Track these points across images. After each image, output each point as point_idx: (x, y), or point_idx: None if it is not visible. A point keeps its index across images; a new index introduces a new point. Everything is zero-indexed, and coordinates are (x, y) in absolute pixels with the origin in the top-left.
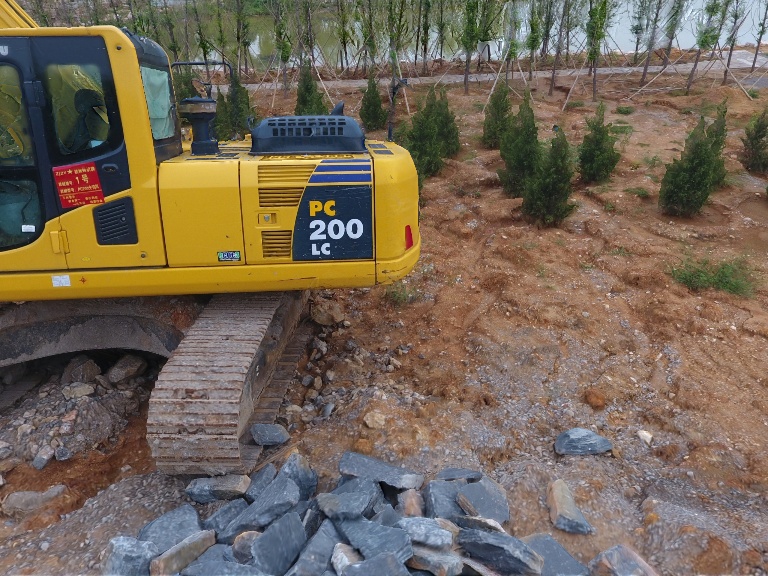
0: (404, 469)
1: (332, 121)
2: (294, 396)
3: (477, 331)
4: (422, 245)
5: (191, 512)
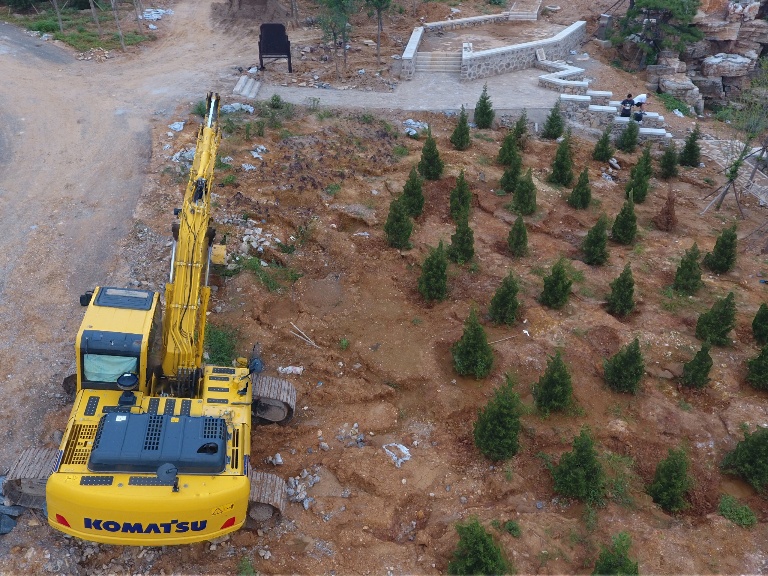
0: None
1: None
2: None
3: None
4: None
5: None
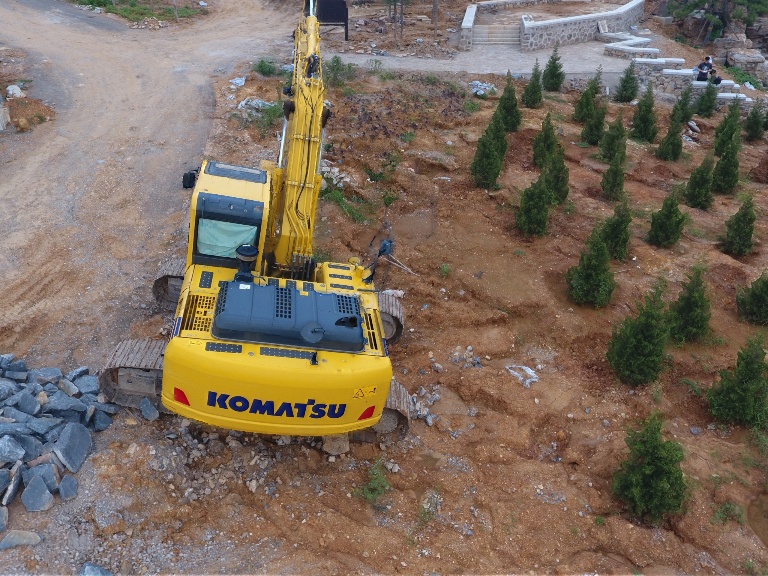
0: (78, 459)
1: None
2: (213, 427)
3: None
4: (504, 517)
5: (97, 388)
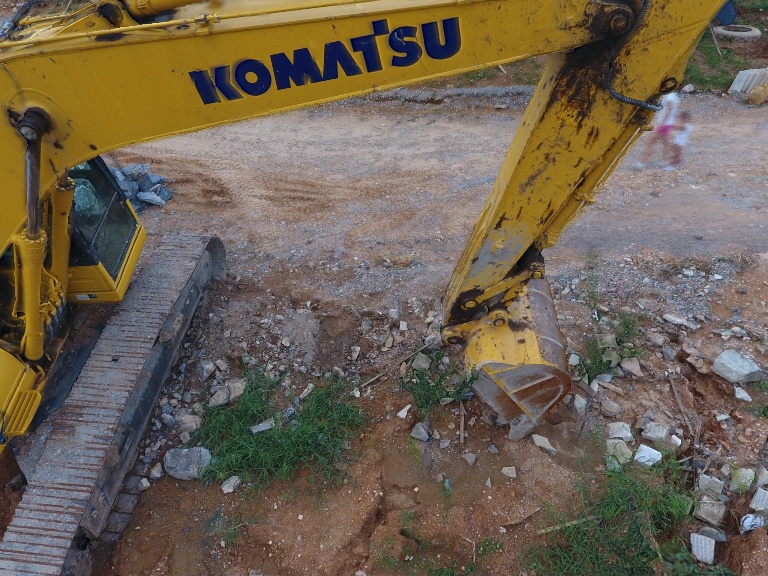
0: None
1: None
2: None
3: None
4: None
5: None
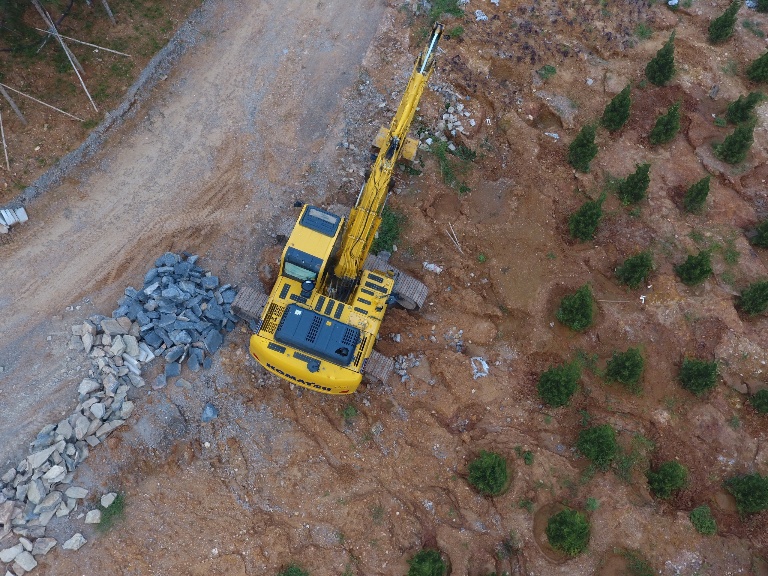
0: (214, 349)
1: (281, 326)
2: None
3: (299, 430)
4: (406, 455)
5: None
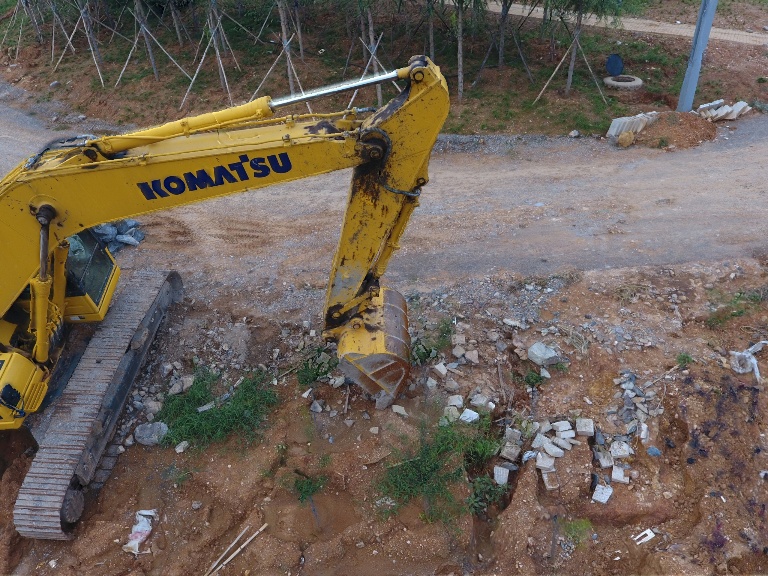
0: None
1: None
2: None
3: None
4: None
5: None
